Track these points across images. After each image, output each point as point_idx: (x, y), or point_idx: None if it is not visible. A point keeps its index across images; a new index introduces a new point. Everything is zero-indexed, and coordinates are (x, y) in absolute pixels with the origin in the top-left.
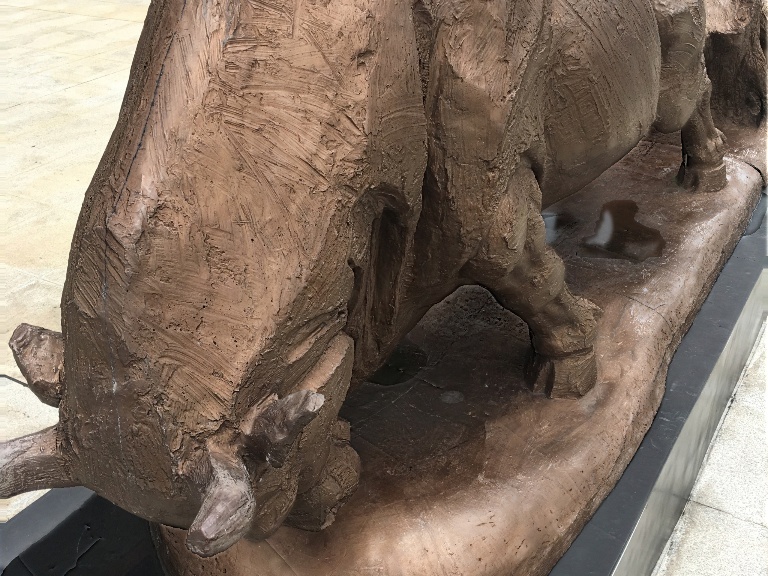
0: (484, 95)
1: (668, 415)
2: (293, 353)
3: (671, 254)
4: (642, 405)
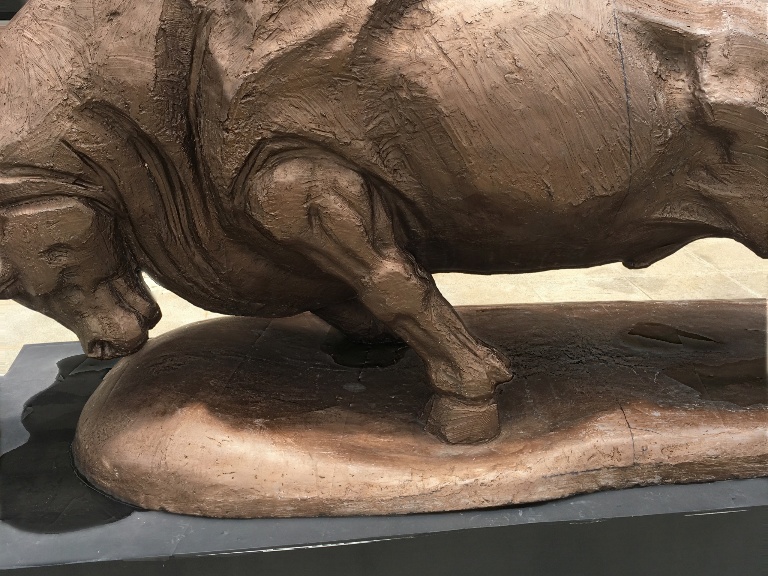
0: (222, 69)
1: (529, 512)
2: (4, 179)
3: (757, 409)
4: (498, 482)
